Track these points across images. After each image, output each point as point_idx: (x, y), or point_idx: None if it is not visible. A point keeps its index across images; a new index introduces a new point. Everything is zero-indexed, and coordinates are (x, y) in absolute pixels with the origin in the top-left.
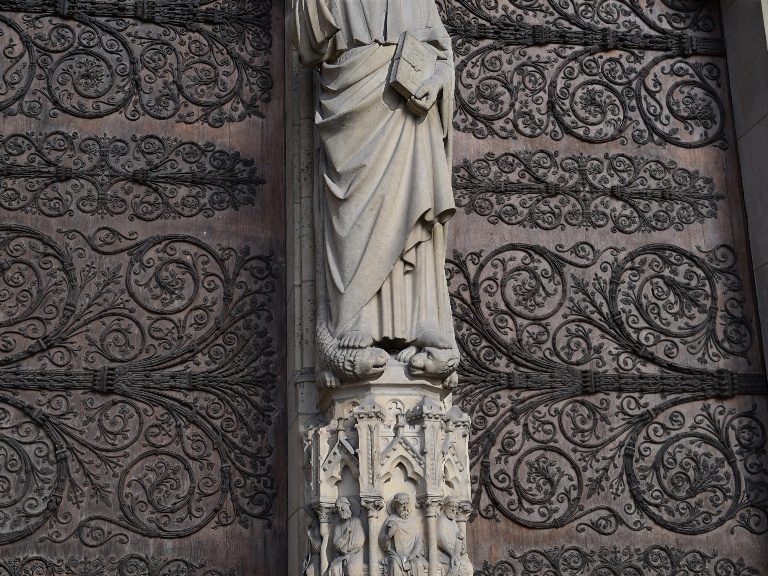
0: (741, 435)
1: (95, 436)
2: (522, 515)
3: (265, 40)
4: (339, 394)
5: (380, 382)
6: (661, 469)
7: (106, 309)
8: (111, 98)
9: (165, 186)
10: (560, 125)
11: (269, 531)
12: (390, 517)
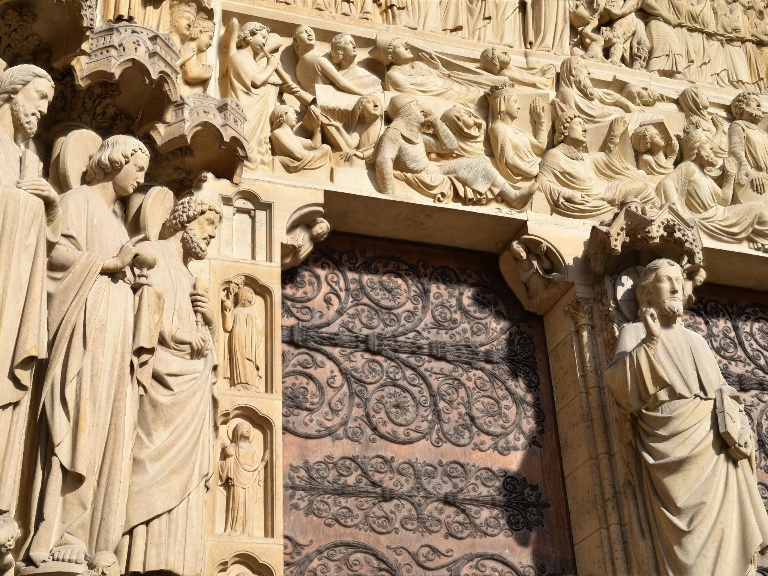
0: None
1: None
2: None
3: (534, 379)
4: None
5: None
6: None
7: None
8: (418, 426)
9: (470, 507)
10: None
11: None
12: None
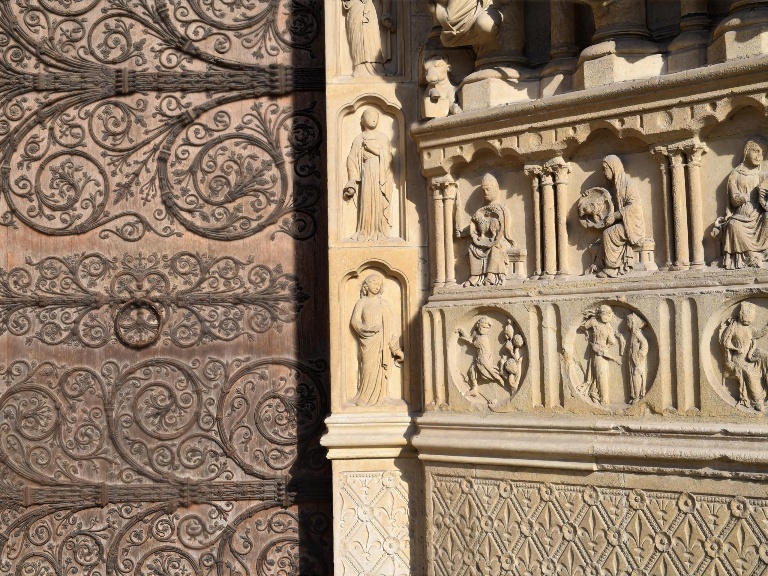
0: (294, 135)
1: None
2: (42, 222)
3: None
4: None
5: None
6: (199, 173)
7: None
8: None
9: None
10: None
11: None
12: None
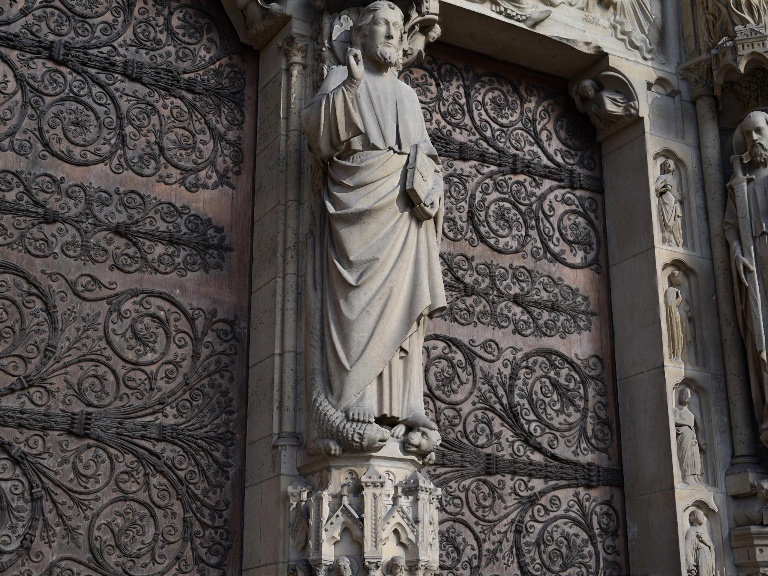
0: (601, 520)
1: (69, 478)
2: None
3: (238, 116)
4: (337, 461)
5: (380, 455)
6: (542, 545)
7: (85, 354)
8: (98, 149)
9: (144, 241)
10: (477, 233)
11: None
12: None
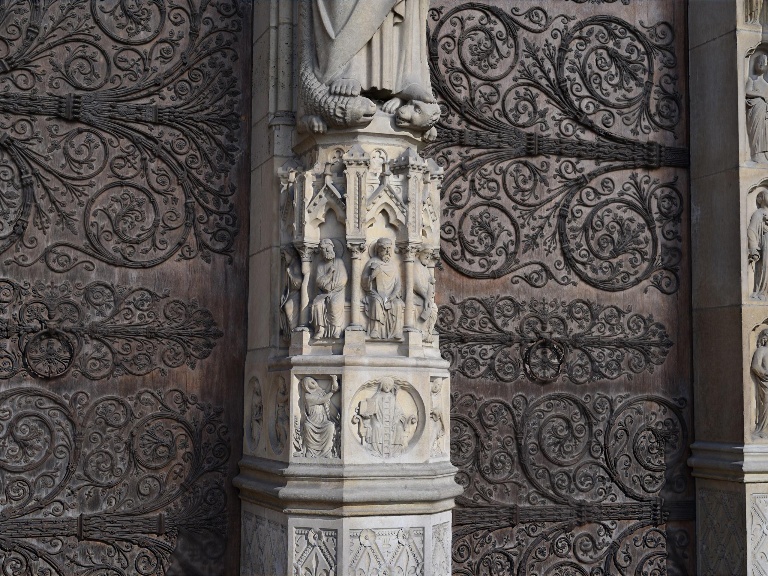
0: (662, 204)
1: (60, 163)
2: (464, 265)
3: None
4: (324, 139)
5: (367, 131)
6: (590, 230)
7: (71, 34)
8: None
9: None
10: None
11: (230, 267)
12: (372, 260)
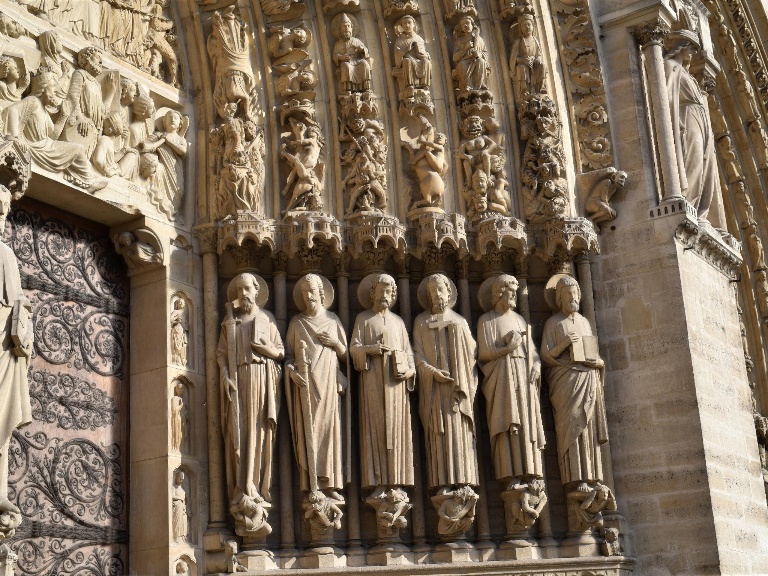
0: (112, 569)
1: None
2: None
3: None
4: None
5: None
6: None
7: None
8: None
9: None
10: (36, 348)
11: None
12: None
